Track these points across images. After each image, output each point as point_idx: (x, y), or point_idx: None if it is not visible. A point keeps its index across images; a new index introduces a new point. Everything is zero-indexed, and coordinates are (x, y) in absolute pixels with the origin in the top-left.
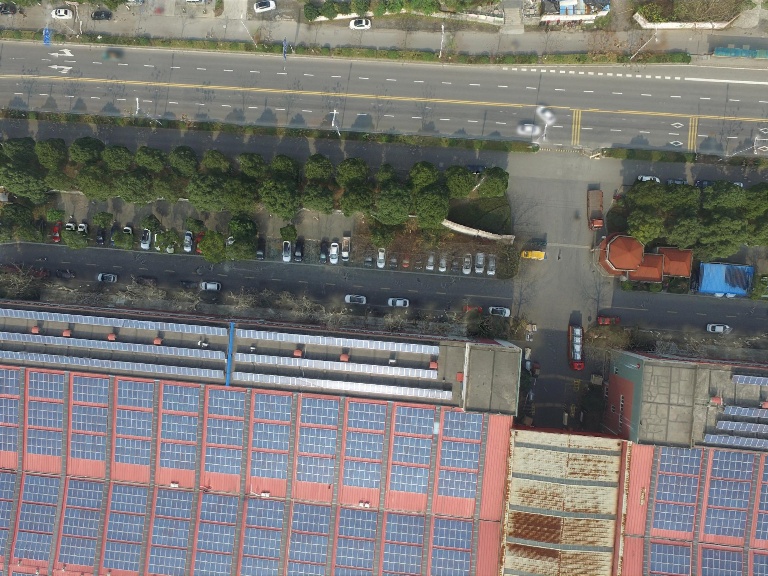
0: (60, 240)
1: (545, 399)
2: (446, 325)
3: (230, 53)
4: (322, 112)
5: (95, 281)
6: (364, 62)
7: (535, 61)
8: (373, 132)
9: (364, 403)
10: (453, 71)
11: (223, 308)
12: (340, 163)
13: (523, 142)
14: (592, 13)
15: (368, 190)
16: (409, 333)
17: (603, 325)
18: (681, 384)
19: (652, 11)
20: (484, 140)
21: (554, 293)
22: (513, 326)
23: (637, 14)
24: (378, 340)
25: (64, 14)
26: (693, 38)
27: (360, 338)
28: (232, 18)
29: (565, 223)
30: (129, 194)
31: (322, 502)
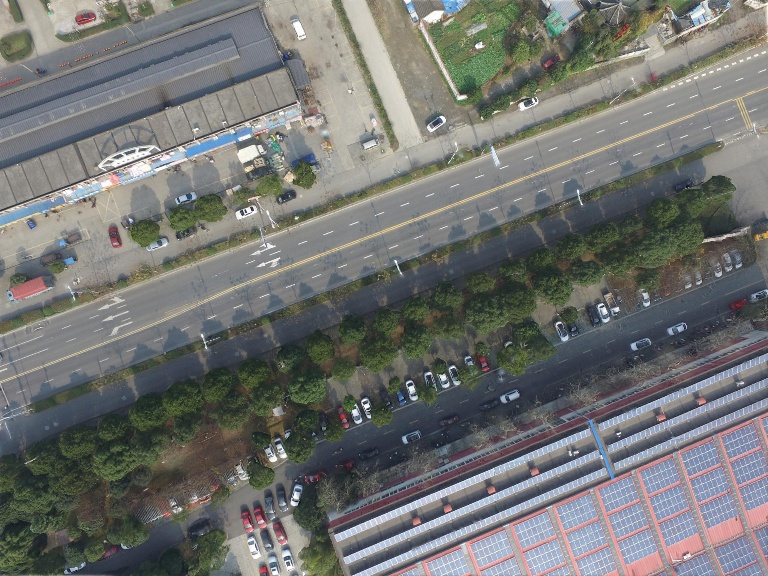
0: (349, 425)
1: None
2: (732, 328)
3: (424, 179)
4: (531, 195)
5: (399, 446)
6: (546, 135)
7: (689, 73)
8: (583, 192)
9: (734, 431)
10: (624, 110)
11: (540, 411)
12: (591, 233)
13: (712, 145)
14: (719, 14)
15: (633, 246)
16: (715, 351)
17: None
18: None
19: None
20: (680, 157)
21: None
22: None
23: (750, 0)
24: (721, 371)
25: (251, 211)
26: None
27: (704, 377)
28: (410, 146)
29: None
30: (420, 351)
31: (736, 535)
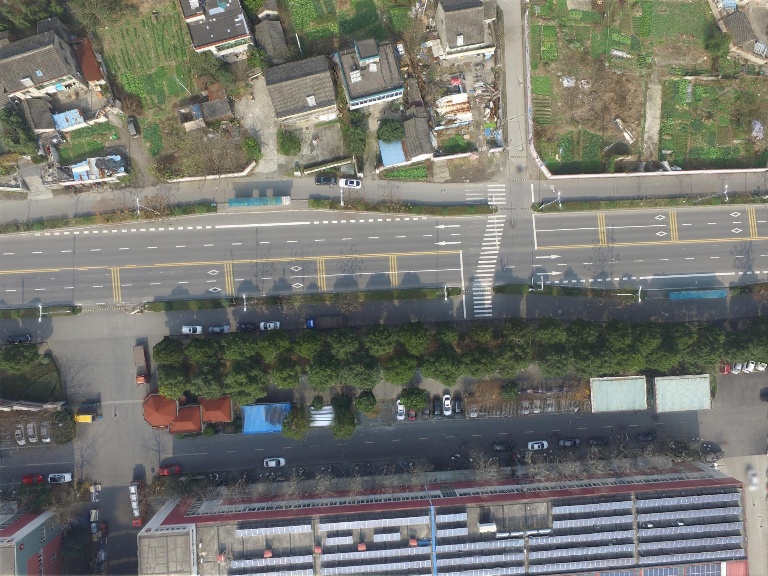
0: None
1: (119, 556)
2: None
3: None
4: None
5: None
6: None
7: (63, 226)
8: None
9: None
10: None
11: None
12: None
13: (61, 307)
14: (107, 177)
15: None
16: None
17: (164, 476)
18: (178, 551)
19: (161, 171)
20: (22, 309)
21: (115, 450)
22: (76, 490)
23: None
24: None
25: None
26: (219, 187)
27: None
28: None
29: (117, 380)
30: None
31: None
